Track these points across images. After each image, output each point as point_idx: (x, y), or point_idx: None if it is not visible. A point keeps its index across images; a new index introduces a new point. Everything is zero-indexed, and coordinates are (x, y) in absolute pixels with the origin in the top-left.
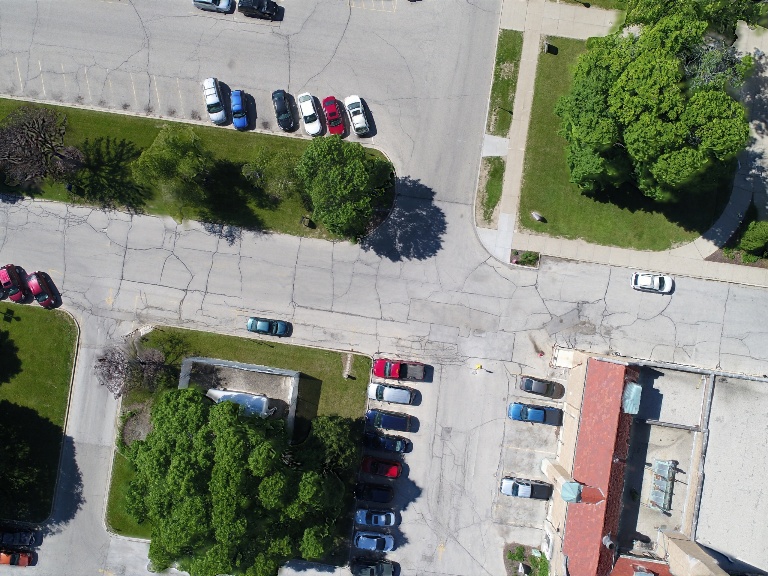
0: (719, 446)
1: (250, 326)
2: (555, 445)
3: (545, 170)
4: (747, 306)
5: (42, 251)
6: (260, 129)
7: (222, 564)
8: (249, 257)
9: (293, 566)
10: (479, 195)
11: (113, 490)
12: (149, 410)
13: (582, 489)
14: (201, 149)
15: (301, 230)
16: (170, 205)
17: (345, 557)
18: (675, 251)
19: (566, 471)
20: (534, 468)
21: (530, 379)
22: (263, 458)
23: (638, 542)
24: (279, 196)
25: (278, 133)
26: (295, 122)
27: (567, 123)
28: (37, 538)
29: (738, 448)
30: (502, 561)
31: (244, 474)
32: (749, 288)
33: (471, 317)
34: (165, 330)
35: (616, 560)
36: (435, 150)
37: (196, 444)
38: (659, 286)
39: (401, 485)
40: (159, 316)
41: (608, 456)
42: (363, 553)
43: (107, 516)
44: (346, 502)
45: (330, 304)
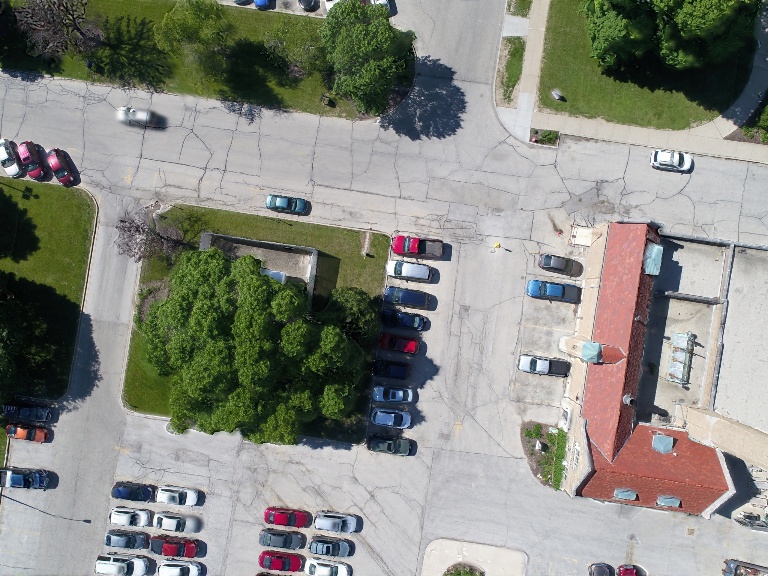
0: (738, 317)
1: (269, 203)
2: (573, 323)
3: (565, 50)
4: (766, 185)
5: (61, 129)
6: (281, 9)
7: (244, 408)
8: (268, 135)
9: (310, 444)
10: (499, 75)
11: (130, 367)
12: (168, 284)
13: (603, 348)
14: (222, 22)
15: (321, 109)
16: (192, 73)
17: (362, 435)
18: (694, 130)
19: (586, 337)
20: (552, 346)
21: (549, 255)
22: (286, 303)
23: (656, 416)
24: (299, 75)
25: (299, 12)
26: (316, 2)
27: (587, 3)
28: (53, 415)
29: (757, 319)
30: (519, 439)
31: (267, 319)
32: (767, 167)
33: (490, 196)
34: (184, 208)
35: (635, 426)
36: (455, 30)
37: (219, 292)
38: (679, 162)
39: (419, 363)
40: (178, 194)
41: (629, 315)
42: (380, 431)
43: (124, 393)
44: (363, 380)
45: (349, 183)
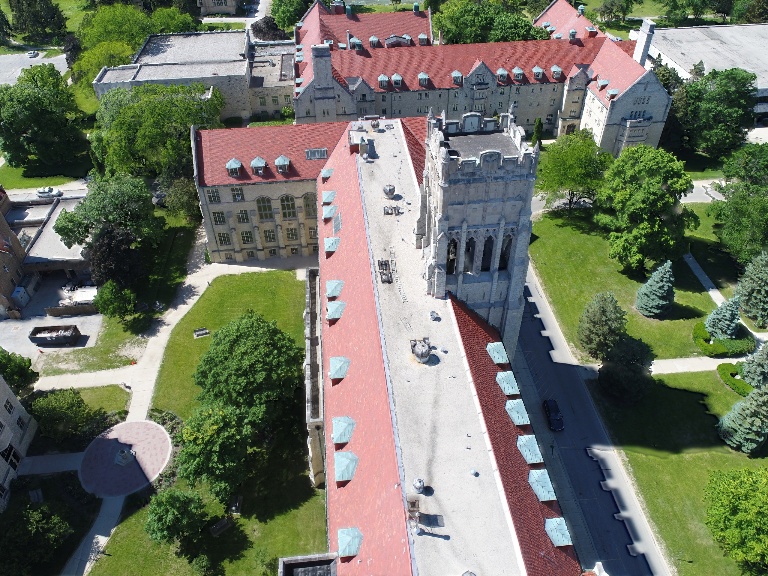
0: None
1: None
2: None
3: None
4: None
5: None
6: None
7: None
8: None
9: None
10: None
11: None
12: None
13: None
14: None
15: None
16: None
17: None
18: (66, 184)
19: None
20: None
21: None
22: None
23: None
24: None
25: None
26: None
27: None
28: None
29: None
30: None
31: None
32: None
33: None
34: None
35: None
36: None
37: None
38: (49, 190)
39: None
40: None
41: None
42: None
43: None
44: None
45: None
